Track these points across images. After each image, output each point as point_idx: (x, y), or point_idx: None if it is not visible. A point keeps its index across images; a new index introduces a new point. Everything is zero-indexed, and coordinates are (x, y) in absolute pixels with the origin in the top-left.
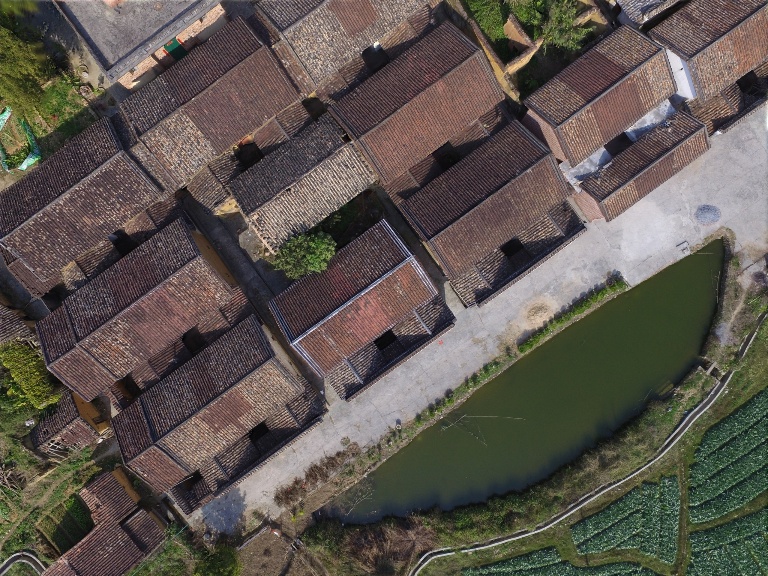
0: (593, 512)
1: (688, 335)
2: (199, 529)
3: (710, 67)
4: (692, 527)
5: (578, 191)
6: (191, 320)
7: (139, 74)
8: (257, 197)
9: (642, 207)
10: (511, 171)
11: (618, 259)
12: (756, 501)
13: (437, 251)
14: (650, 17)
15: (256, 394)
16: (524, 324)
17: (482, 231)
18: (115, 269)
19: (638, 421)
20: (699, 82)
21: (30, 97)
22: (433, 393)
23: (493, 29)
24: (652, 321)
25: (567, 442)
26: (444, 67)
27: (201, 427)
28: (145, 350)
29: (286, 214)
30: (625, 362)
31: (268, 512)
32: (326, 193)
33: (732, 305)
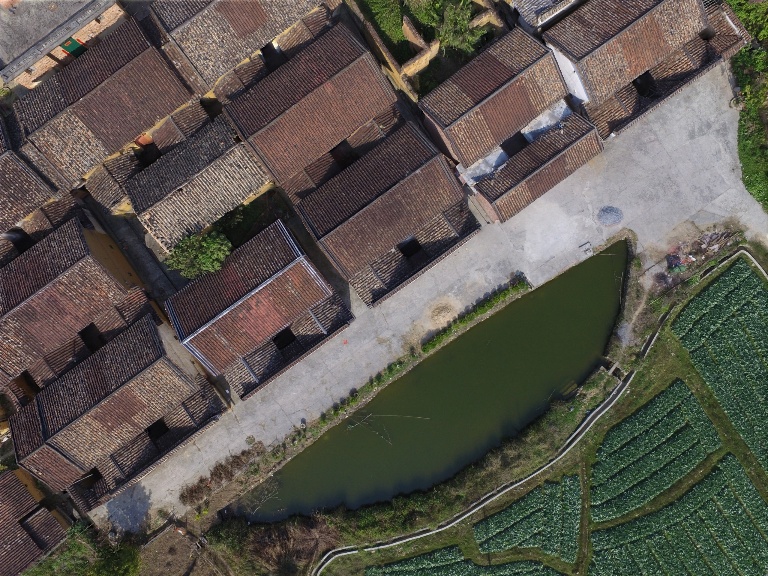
0: (496, 511)
1: (592, 335)
2: (104, 527)
3: (600, 70)
4: (594, 526)
5: (475, 192)
6: (84, 319)
7: (39, 74)
8: (150, 197)
9: (545, 208)
10: (401, 172)
11: (521, 260)
12: (657, 500)
13: (328, 251)
14: (543, 20)
15: (149, 393)
16: (428, 324)
17: (374, 231)
18: (9, 268)
19: (540, 421)
20: (590, 84)
21: None
22: (338, 392)
23: (393, 31)
24: (556, 321)
25: (472, 441)
26: (333, 68)
27: (94, 426)
28: (38, 349)
29: (179, 214)
30: (529, 362)
31: (173, 510)
32: (219, 193)
33: (634, 306)
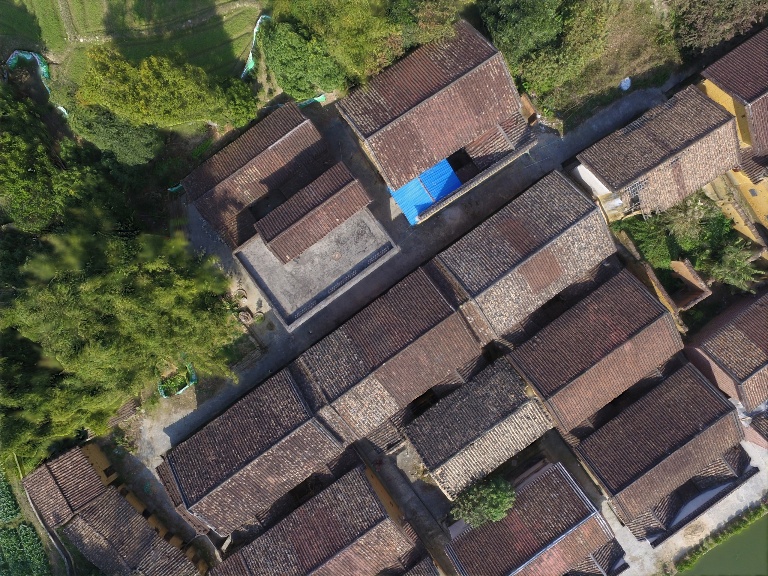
0: None
1: None
2: None
3: None
4: None
5: (745, 426)
6: (372, 572)
7: None
8: (439, 450)
9: None
10: (693, 424)
11: None
12: None
13: (619, 503)
14: None
15: None
16: (680, 542)
17: (662, 480)
18: (293, 520)
19: None
20: None
21: (218, 363)
22: None
23: (659, 261)
24: None
25: None
26: (631, 326)
27: None
28: None
29: (467, 465)
30: None
31: None
32: (506, 443)
33: None
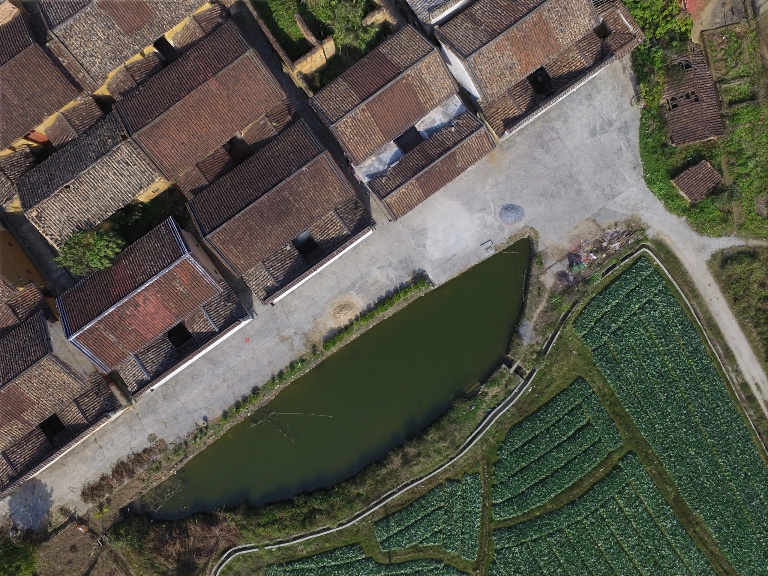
0: (397, 509)
1: (496, 333)
2: (6, 525)
3: (489, 67)
4: (495, 524)
5: (370, 190)
6: None
7: None
8: (38, 194)
9: (447, 206)
10: (288, 169)
11: (423, 258)
12: (558, 498)
13: (216, 248)
14: (434, 17)
15: (38, 390)
16: (330, 322)
17: (262, 229)
18: None
19: (442, 419)
20: (479, 82)
21: None
22: (240, 390)
23: (290, 28)
24: (459, 319)
25: (375, 439)
26: (218, 66)
27: None
28: None
29: (68, 211)
30: (432, 360)
31: (75, 508)
32: (109, 190)
33: (535, 304)
